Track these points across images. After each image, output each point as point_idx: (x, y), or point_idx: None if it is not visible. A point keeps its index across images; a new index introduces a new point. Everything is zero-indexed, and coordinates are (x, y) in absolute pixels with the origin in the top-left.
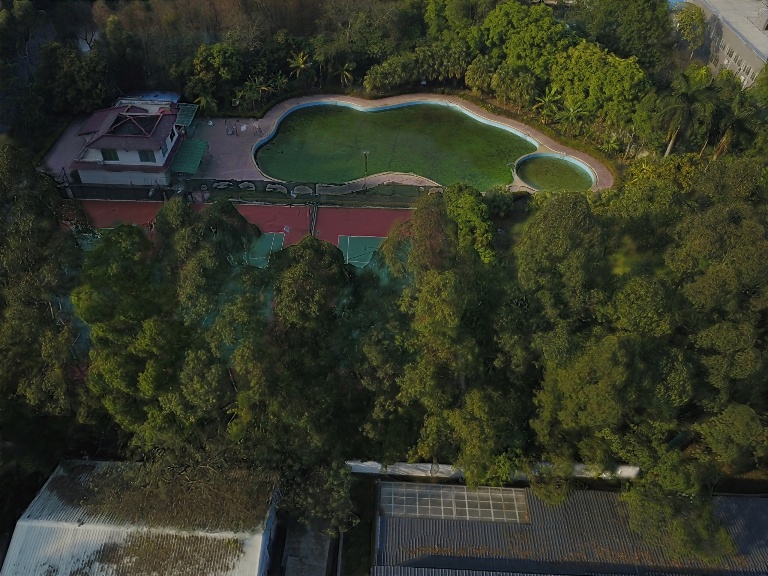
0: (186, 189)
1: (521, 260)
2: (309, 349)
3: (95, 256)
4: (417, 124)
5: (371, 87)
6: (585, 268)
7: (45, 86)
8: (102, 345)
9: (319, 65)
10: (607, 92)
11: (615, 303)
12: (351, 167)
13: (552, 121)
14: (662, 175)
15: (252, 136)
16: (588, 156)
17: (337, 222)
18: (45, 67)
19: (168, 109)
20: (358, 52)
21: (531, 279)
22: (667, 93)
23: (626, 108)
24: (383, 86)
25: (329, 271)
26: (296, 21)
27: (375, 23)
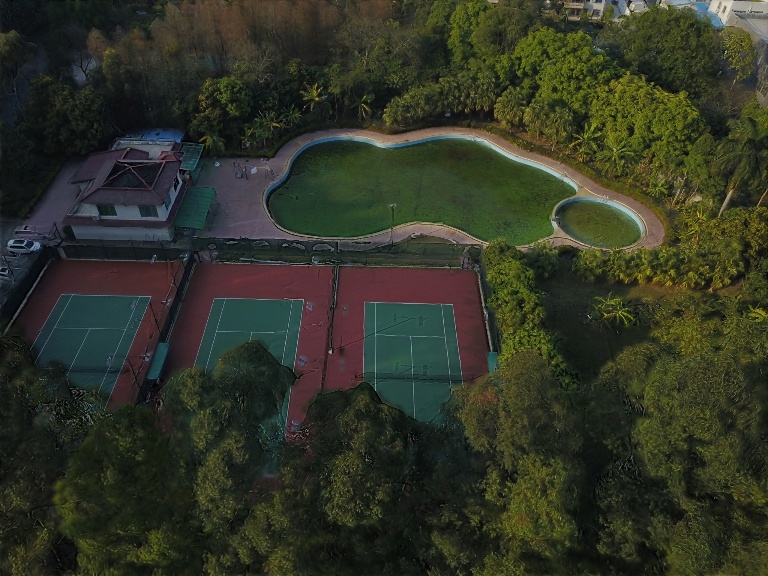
0: (192, 248)
1: (647, 438)
2: (361, 536)
3: (82, 457)
4: (443, 162)
5: (391, 121)
6: (736, 455)
7: (35, 126)
8: (94, 552)
9: (335, 97)
10: (656, 131)
11: (765, 487)
12: (373, 215)
13: (590, 159)
14: (727, 232)
15: (263, 179)
16: (633, 200)
17: (362, 285)
18: (35, 104)
19: (171, 154)
20: (376, 82)
21: (660, 464)
22: (723, 133)
23: (677, 149)
24: (404, 119)
25: (392, 449)
26: (308, 48)
27: (395, 50)
